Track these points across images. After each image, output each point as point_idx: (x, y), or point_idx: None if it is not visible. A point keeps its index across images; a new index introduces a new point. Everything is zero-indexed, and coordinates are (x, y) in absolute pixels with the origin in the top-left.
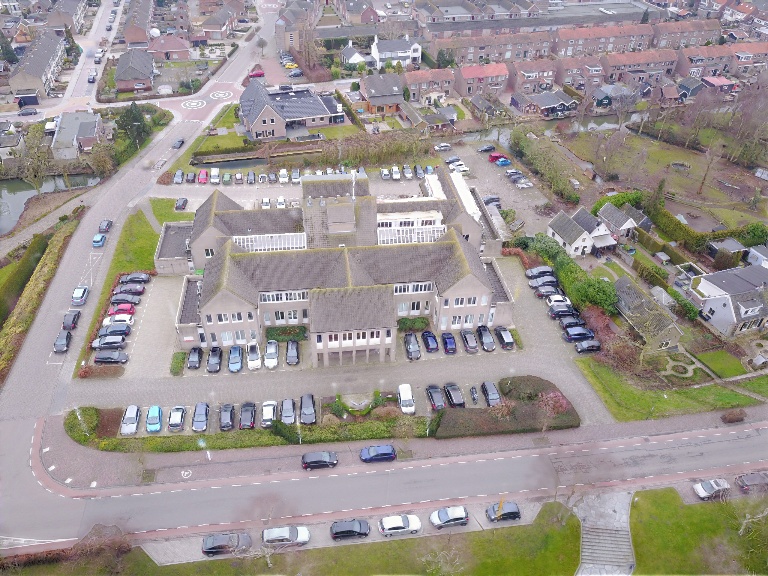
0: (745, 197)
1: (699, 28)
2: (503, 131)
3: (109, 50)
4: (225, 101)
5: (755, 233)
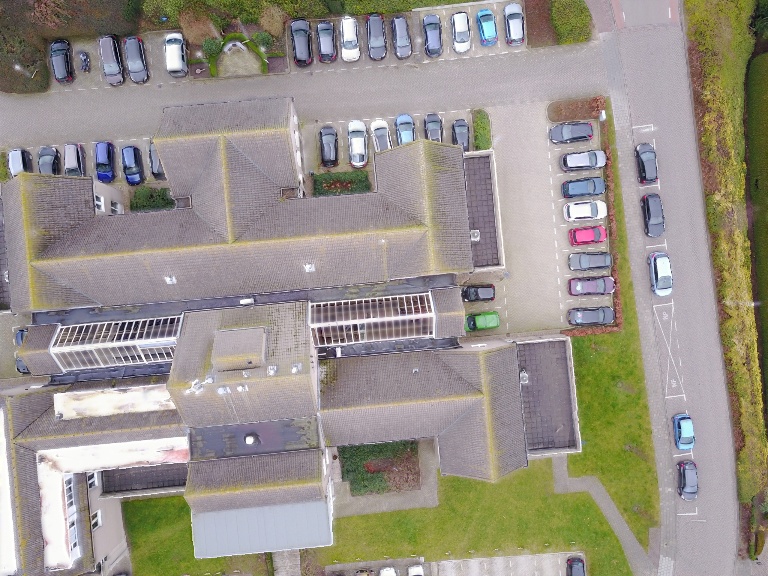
0: None
1: None
2: None
3: None
4: None
5: None
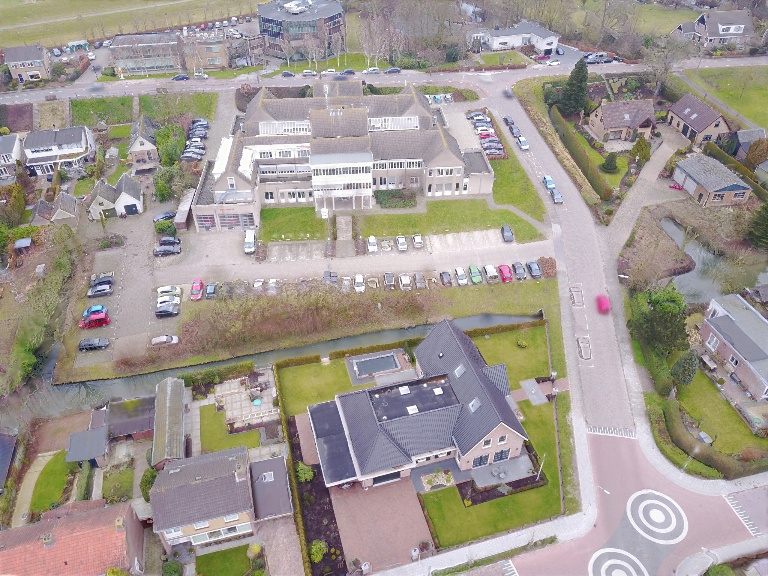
0: None
1: None
2: None
3: None
4: (591, 533)
5: None
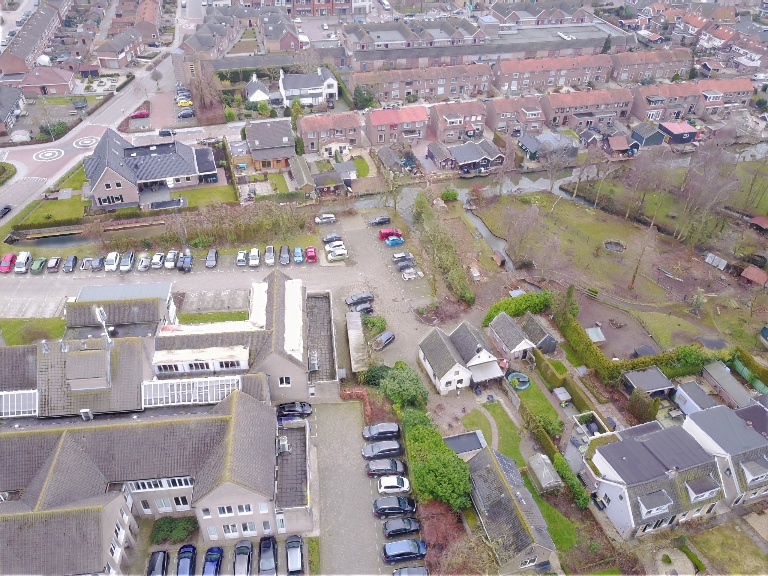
0: (687, 295)
1: (666, 59)
2: (415, 190)
3: None
4: (88, 151)
5: (687, 360)
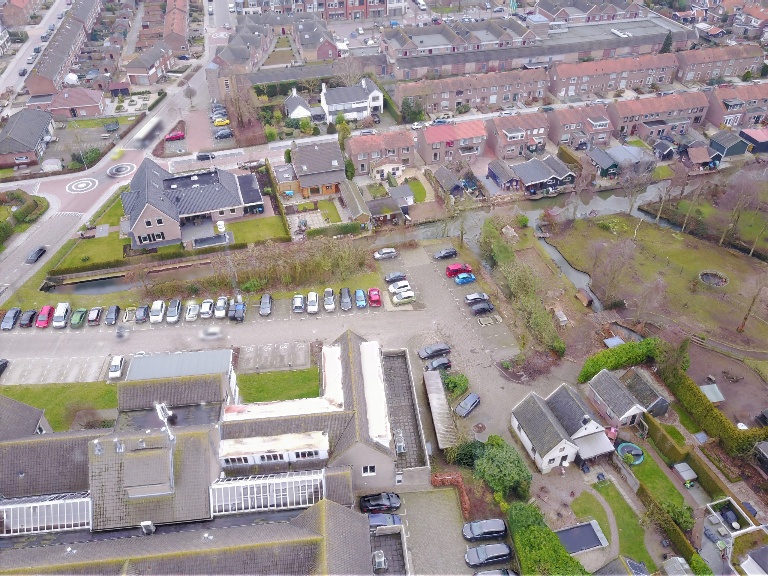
0: None
1: (736, 55)
2: (476, 214)
3: (10, 104)
4: (123, 180)
5: None
